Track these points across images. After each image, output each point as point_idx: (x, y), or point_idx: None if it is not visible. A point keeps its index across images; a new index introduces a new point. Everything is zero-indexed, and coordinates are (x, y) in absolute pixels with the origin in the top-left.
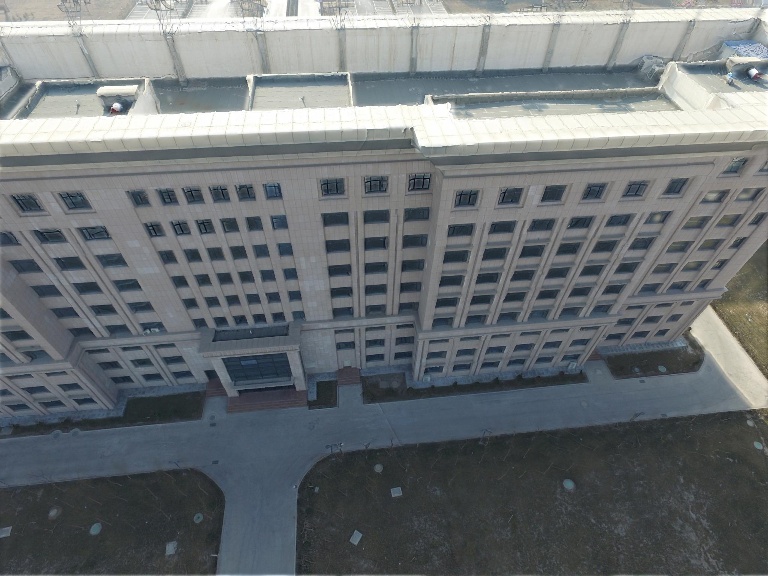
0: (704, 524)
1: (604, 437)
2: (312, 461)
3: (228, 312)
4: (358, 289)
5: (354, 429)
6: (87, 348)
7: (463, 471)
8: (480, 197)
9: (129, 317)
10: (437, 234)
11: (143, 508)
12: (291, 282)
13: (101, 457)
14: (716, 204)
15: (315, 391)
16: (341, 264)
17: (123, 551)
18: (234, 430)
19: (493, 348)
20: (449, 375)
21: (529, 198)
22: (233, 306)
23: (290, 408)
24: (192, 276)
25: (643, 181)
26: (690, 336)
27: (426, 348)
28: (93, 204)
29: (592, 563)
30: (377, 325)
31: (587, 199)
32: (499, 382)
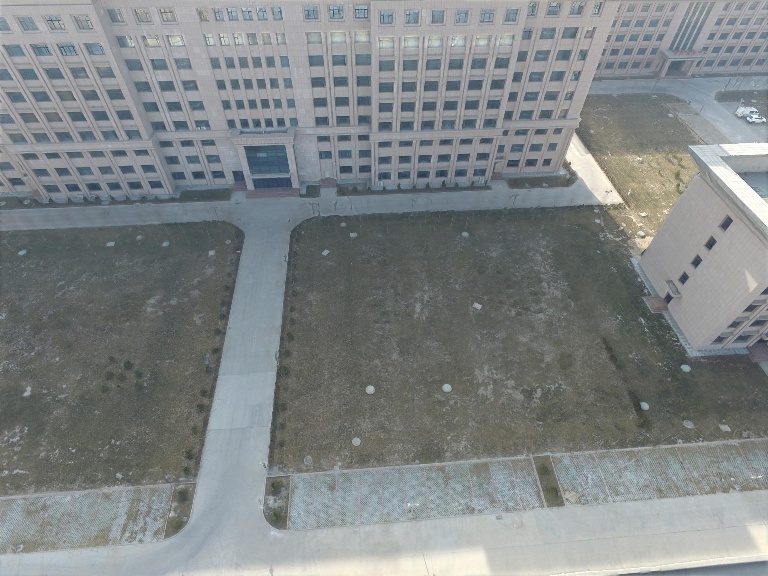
0: (548, 253)
1: (495, 215)
2: (301, 220)
3: (249, 115)
4: (331, 99)
5: (329, 208)
6: (161, 139)
7: (398, 227)
8: (394, 17)
9: (189, 114)
10: (372, 44)
11: (194, 236)
12: (288, 90)
13: (166, 215)
14: (551, 40)
15: (305, 189)
16: (319, 77)
17: (183, 253)
18: (251, 206)
19: (424, 159)
20: (396, 183)
21: (423, 19)
22: (252, 110)
23: (288, 197)
24: (229, 80)
25: (491, 10)
26: (571, 170)
27: (377, 151)
28: (177, 17)
29: (471, 267)
30: (345, 134)
31: (459, 23)
32: (430, 187)
